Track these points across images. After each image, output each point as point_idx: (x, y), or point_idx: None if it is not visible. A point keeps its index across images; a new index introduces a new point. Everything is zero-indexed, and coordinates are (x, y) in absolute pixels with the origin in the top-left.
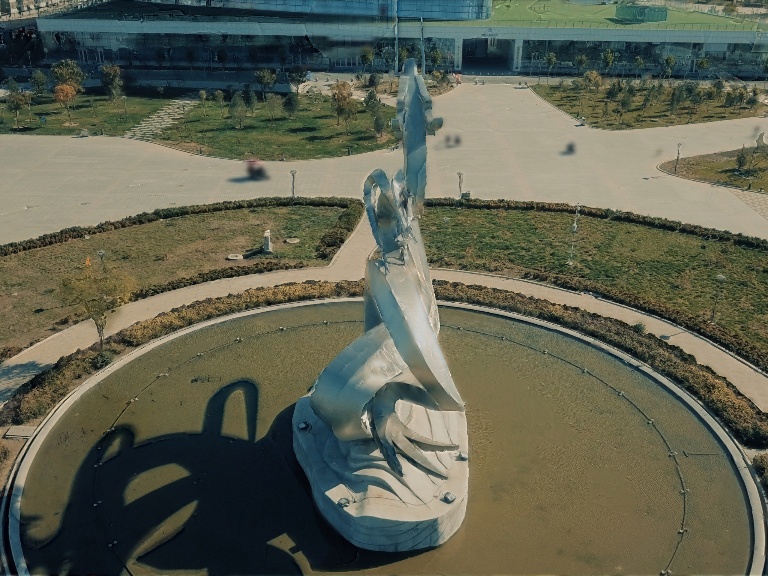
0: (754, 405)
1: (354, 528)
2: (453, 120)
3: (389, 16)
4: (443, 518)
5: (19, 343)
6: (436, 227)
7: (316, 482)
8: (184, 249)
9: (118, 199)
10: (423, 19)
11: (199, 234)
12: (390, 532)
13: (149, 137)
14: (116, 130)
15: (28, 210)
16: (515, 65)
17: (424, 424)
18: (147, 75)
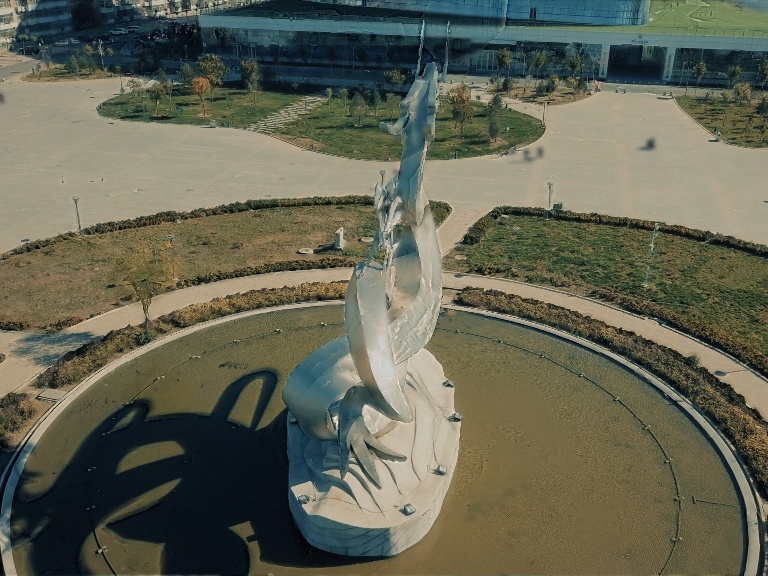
0: None
1: (308, 526)
2: (577, 128)
3: (498, 19)
4: (396, 529)
5: (83, 314)
6: (516, 237)
7: None
8: (262, 240)
9: (220, 188)
10: (570, 23)
11: (281, 226)
12: (340, 535)
13: (270, 131)
14: (243, 123)
15: (137, 193)
16: (665, 74)
17: (409, 433)
18: (290, 71)
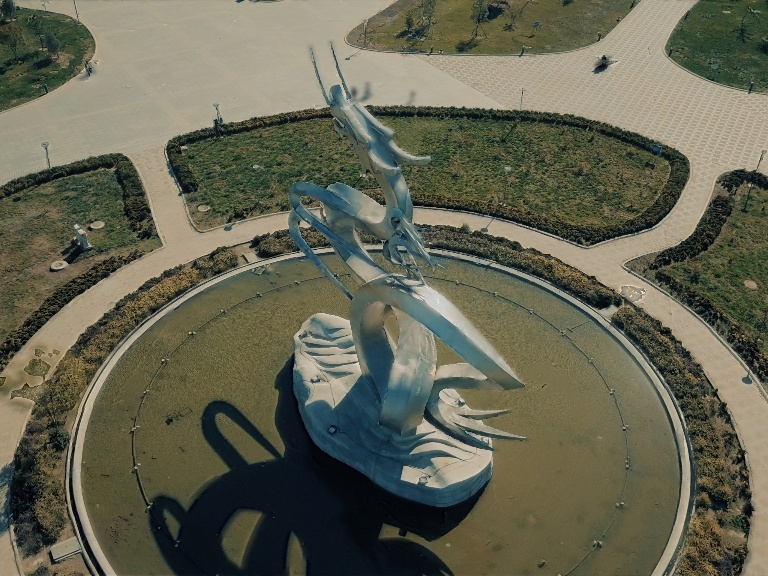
0: (580, 271)
1: (440, 496)
2: (113, 17)
3: None
4: None
5: None
6: (219, 167)
7: (382, 473)
8: None
9: None
10: None
11: None
12: (467, 487)
13: None
14: None
15: None
16: None
17: None
18: None
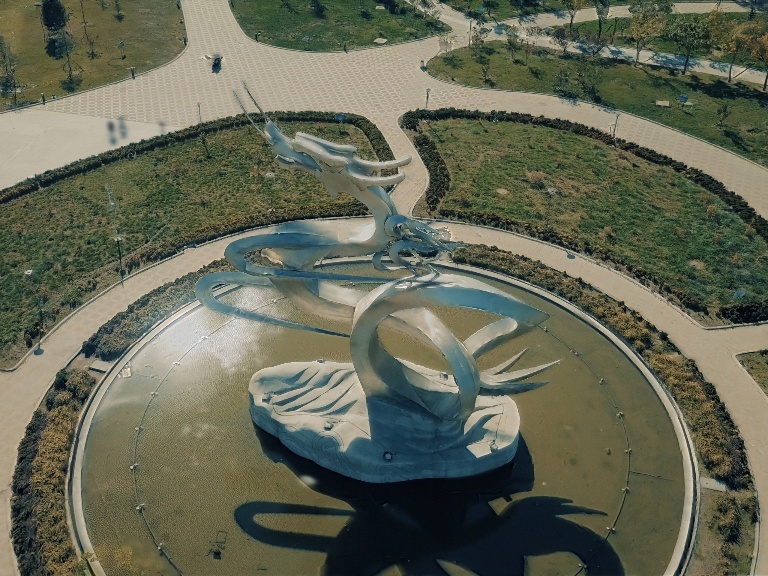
0: None
1: None
2: None
3: None
4: None
5: None
6: None
7: None
8: None
9: None
10: None
11: None
12: None
13: None
14: None
15: None
16: None
17: None
18: None
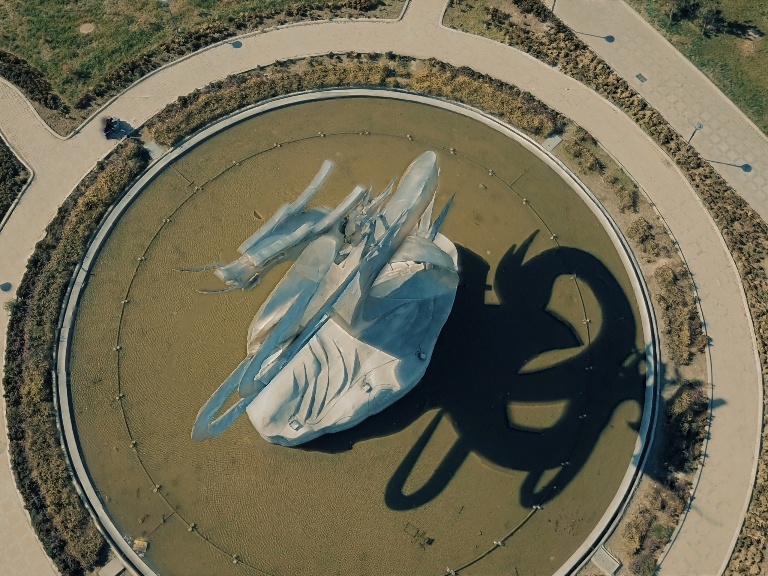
0: None
1: None
2: None
3: None
4: None
5: None
6: None
7: None
8: None
9: None
10: None
11: None
12: None
13: None
14: None
15: None
16: None
17: None
18: None
